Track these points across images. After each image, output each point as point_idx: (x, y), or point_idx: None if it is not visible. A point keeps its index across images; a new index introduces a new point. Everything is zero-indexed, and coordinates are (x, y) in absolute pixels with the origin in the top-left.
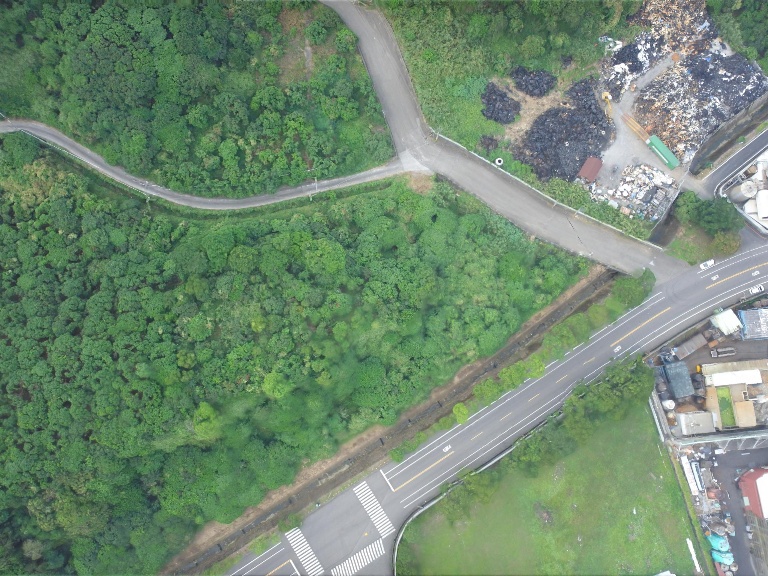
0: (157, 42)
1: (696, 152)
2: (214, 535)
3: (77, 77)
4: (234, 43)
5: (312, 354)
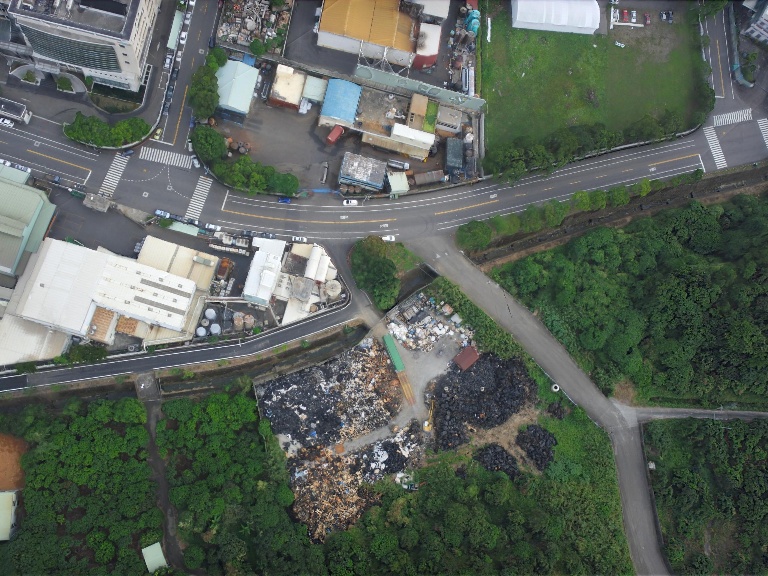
0: None
1: None
2: None
3: None
4: None
5: None
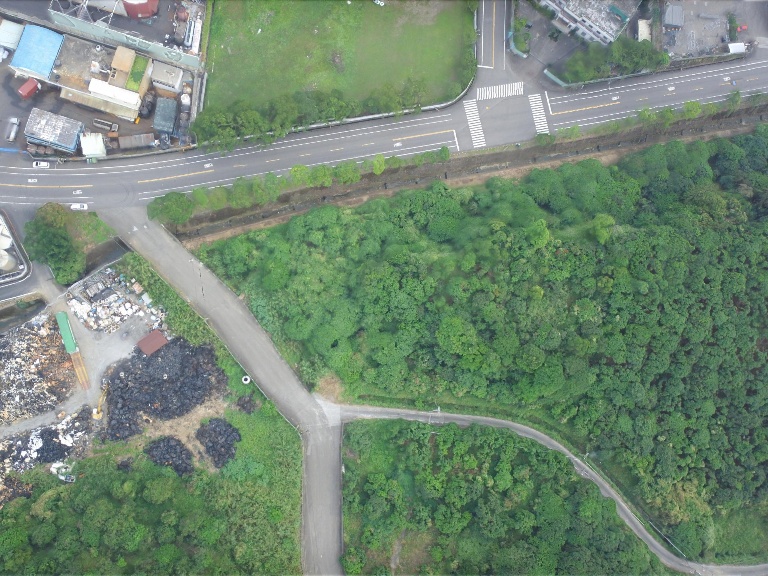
0: None
1: None
2: (603, 157)
3: None
4: None
5: (502, 248)
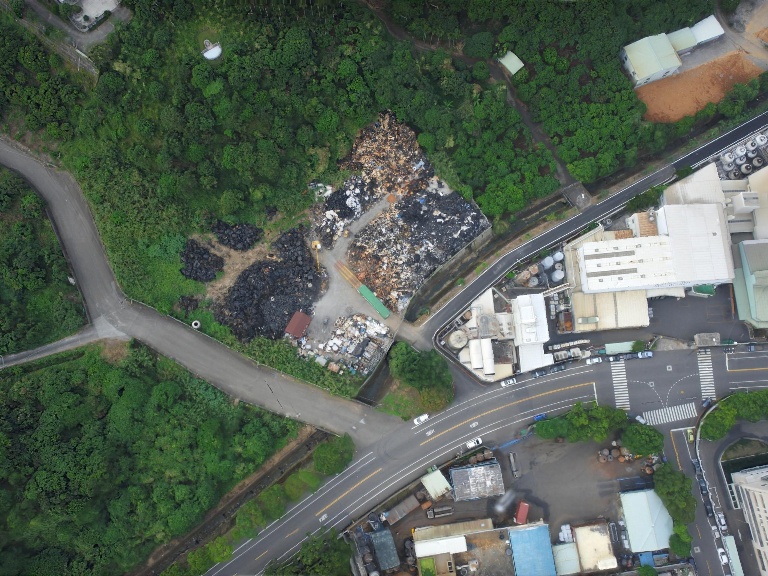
0: None
1: (414, 297)
2: None
3: None
4: None
5: None
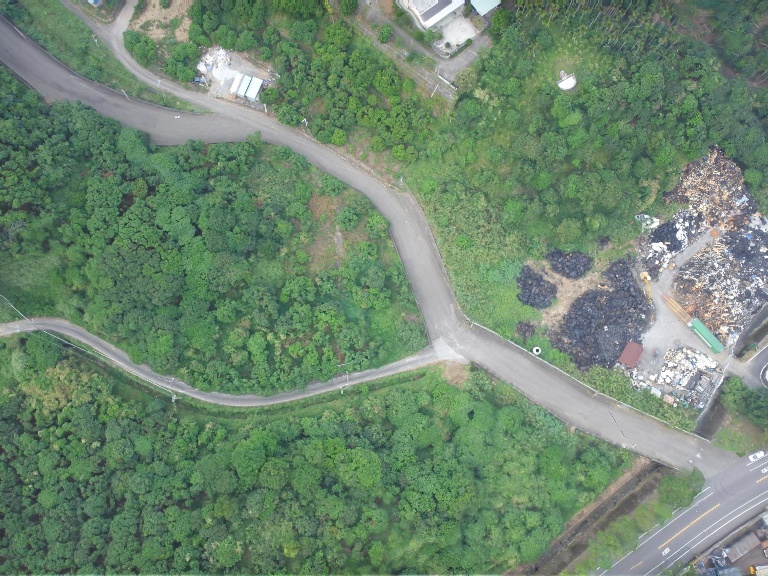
0: (186, 240)
1: (739, 332)
2: None
3: (103, 280)
4: (263, 234)
5: None
